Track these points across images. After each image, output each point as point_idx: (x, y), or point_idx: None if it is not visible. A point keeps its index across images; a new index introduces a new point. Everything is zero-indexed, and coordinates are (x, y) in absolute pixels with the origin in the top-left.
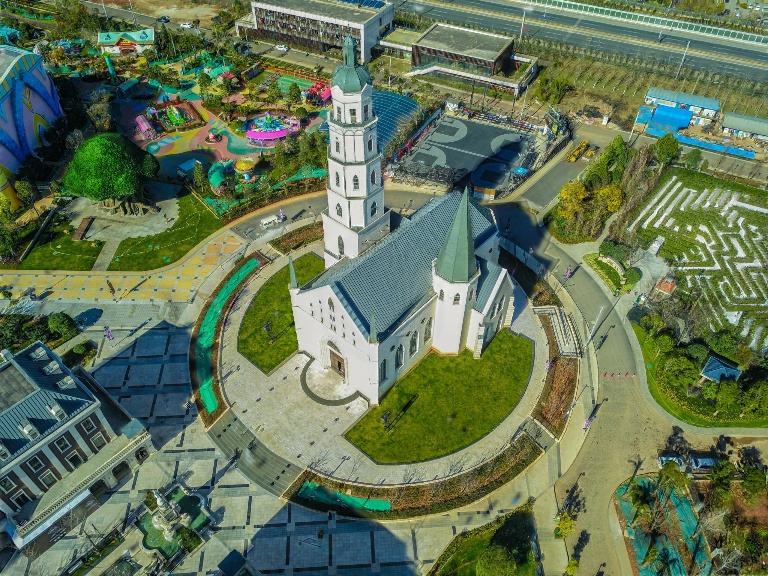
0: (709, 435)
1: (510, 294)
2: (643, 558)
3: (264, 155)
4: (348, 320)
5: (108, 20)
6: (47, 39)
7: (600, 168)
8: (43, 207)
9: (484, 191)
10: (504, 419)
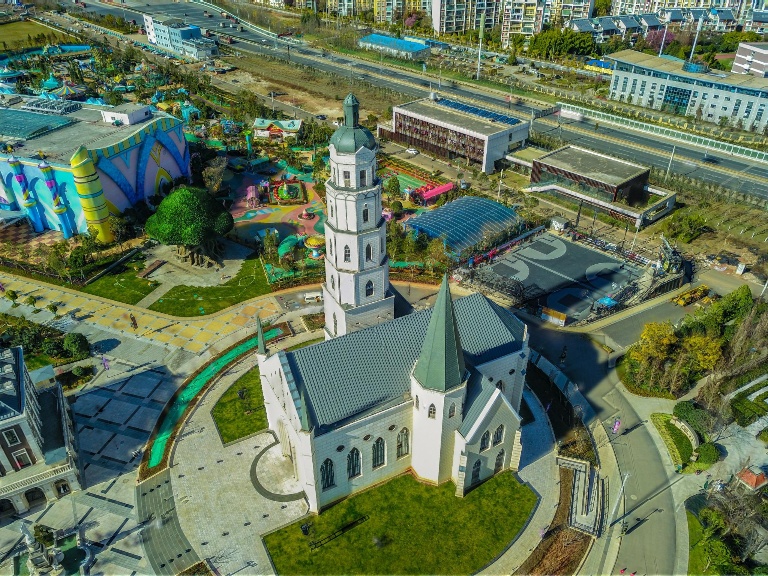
0: None
1: (515, 427)
2: None
3: None
4: (290, 399)
5: None
6: (219, 120)
7: (708, 316)
8: (129, 244)
9: (553, 314)
10: None
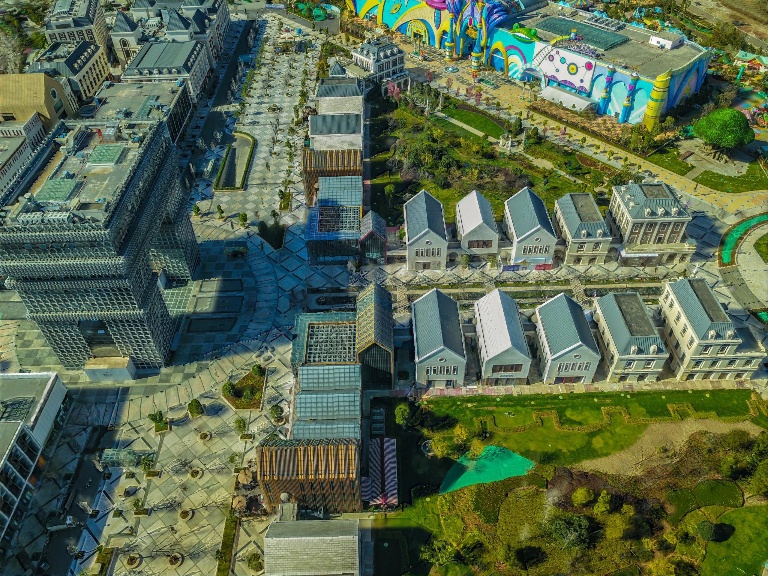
0: None
1: None
2: None
3: None
4: None
5: None
6: None
7: None
8: (669, 136)
9: None
10: None
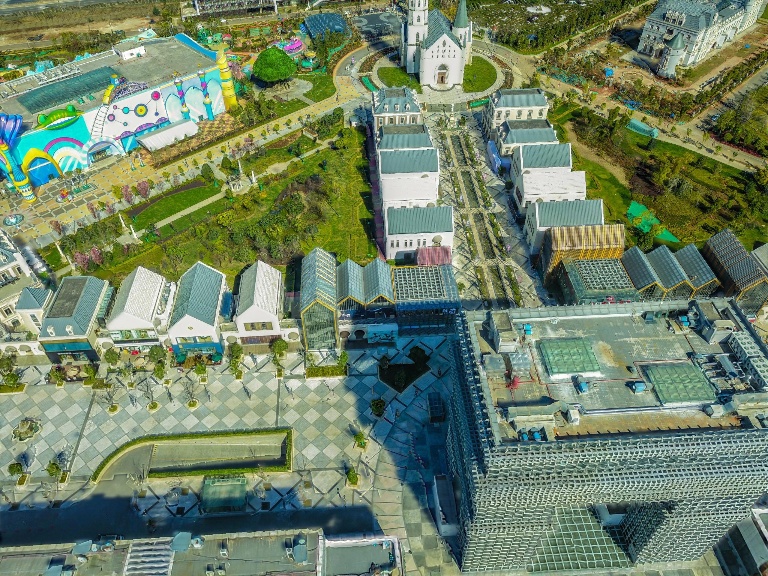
0: (542, 55)
1: None
2: (556, 78)
3: (303, 54)
4: (453, 45)
5: (114, 34)
6: None
7: None
8: None
9: None
10: (496, 71)
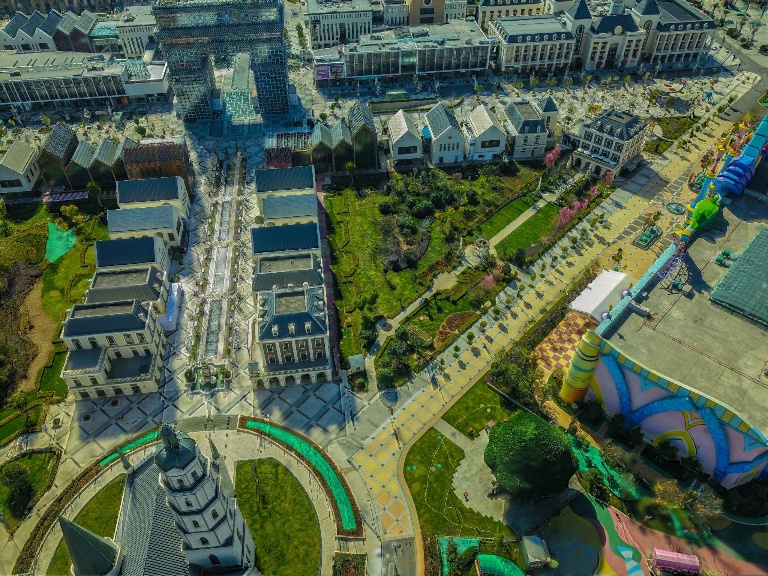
0: None
1: None
2: None
3: None
4: None
5: None
6: None
7: None
8: (548, 413)
9: None
10: (48, 570)
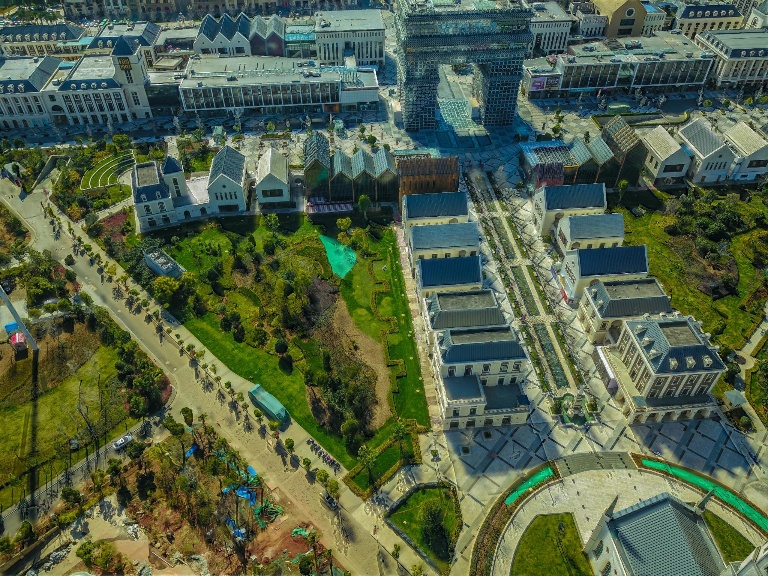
0: None
1: None
2: None
3: None
4: None
5: None
6: None
7: None
8: None
9: None
10: None
